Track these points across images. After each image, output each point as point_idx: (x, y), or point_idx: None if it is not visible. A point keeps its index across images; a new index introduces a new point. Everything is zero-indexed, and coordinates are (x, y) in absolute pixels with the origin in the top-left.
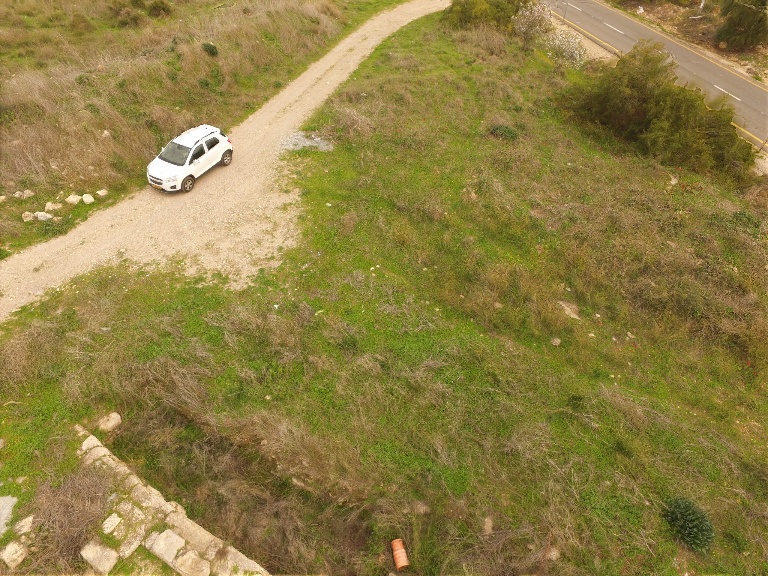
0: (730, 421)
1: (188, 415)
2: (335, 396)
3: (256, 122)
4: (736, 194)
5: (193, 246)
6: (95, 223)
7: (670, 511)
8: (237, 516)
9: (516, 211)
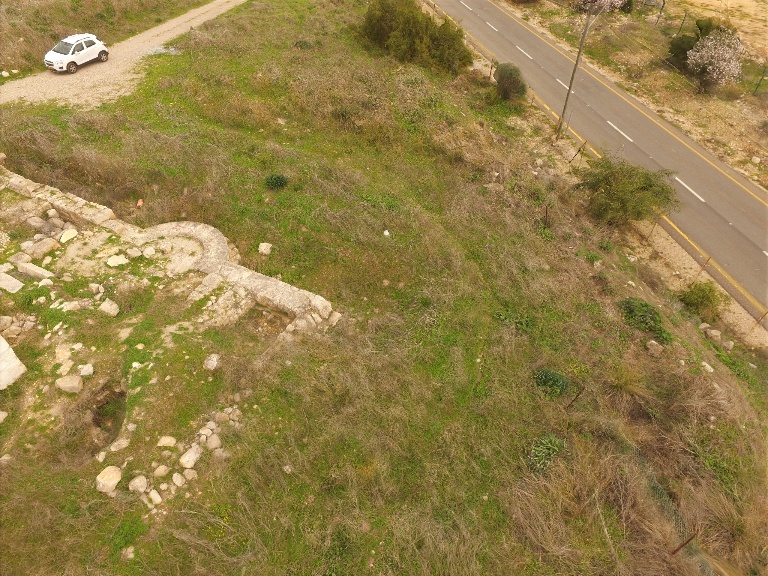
0: (335, 158)
1: (46, 161)
2: (123, 146)
3: (134, 41)
4: (451, 81)
5: (67, 95)
6: (8, 86)
7: (268, 177)
8: (60, 189)
9: (281, 82)
